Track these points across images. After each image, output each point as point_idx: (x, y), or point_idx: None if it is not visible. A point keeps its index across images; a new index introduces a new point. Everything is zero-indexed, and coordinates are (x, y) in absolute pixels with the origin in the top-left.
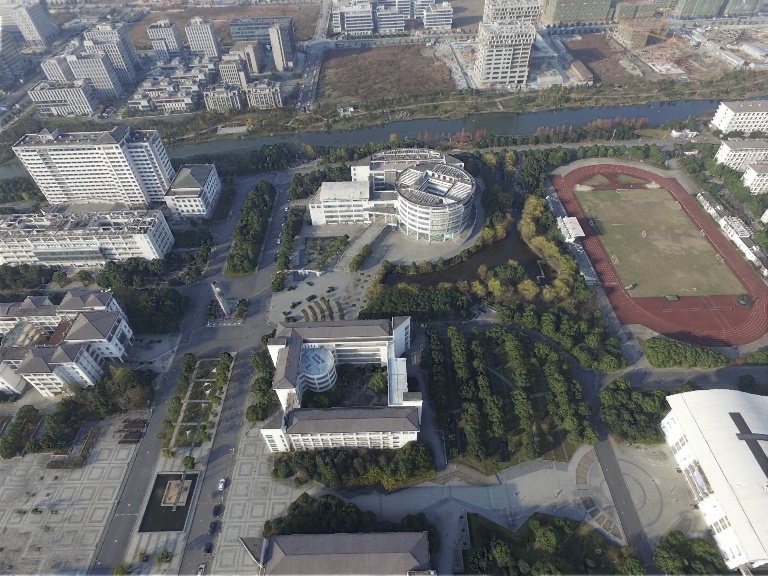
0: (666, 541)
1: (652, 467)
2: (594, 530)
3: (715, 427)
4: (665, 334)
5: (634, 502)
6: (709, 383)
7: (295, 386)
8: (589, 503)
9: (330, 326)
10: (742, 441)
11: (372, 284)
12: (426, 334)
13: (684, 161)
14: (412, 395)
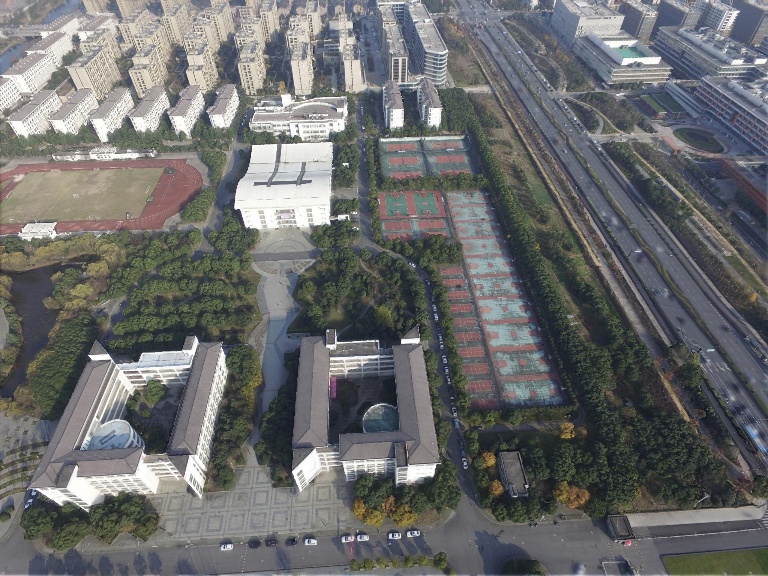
0: (315, 241)
1: (273, 239)
2: (305, 271)
3: (261, 193)
4: (180, 210)
5: (292, 251)
6: (224, 203)
7: (141, 447)
8: (289, 271)
9: (69, 418)
10: (271, 186)
11: (6, 405)
12: (112, 351)
13: (5, 152)
14: (187, 343)
